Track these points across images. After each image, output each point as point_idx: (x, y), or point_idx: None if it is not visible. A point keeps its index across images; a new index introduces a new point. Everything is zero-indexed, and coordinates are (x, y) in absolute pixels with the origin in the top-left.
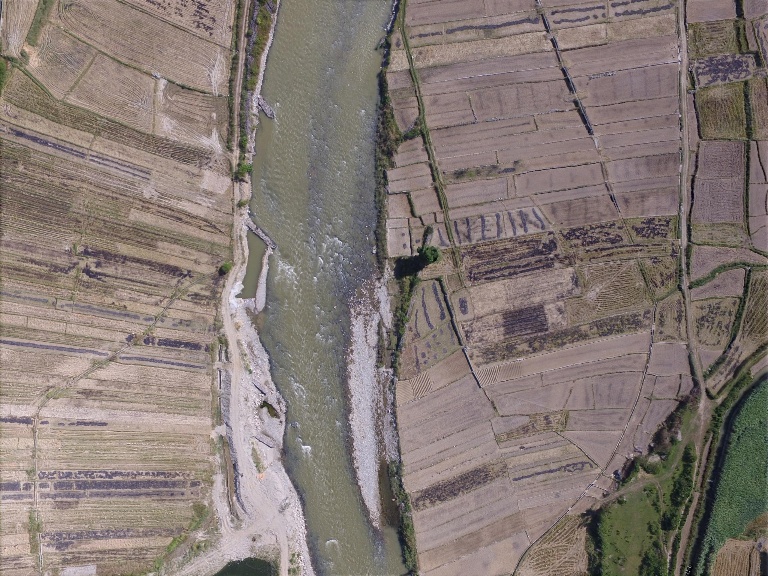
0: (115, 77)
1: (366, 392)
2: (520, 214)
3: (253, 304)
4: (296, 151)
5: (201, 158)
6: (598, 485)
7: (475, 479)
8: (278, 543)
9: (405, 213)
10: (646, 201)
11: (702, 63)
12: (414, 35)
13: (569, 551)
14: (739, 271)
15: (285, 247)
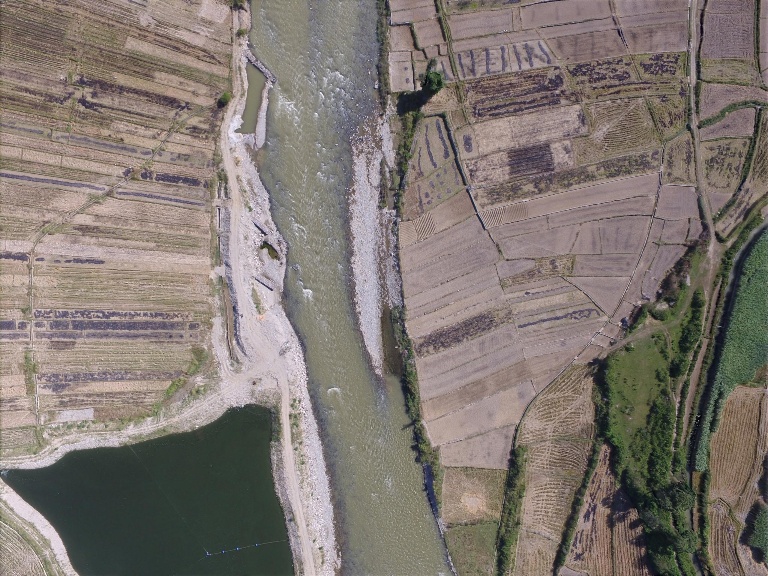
0: None
1: (368, 234)
2: (525, 47)
3: (253, 140)
4: None
5: None
6: (605, 333)
7: (480, 325)
8: (279, 387)
9: (408, 46)
10: (654, 37)
11: None
12: None
13: (575, 402)
14: (749, 110)
15: (285, 81)
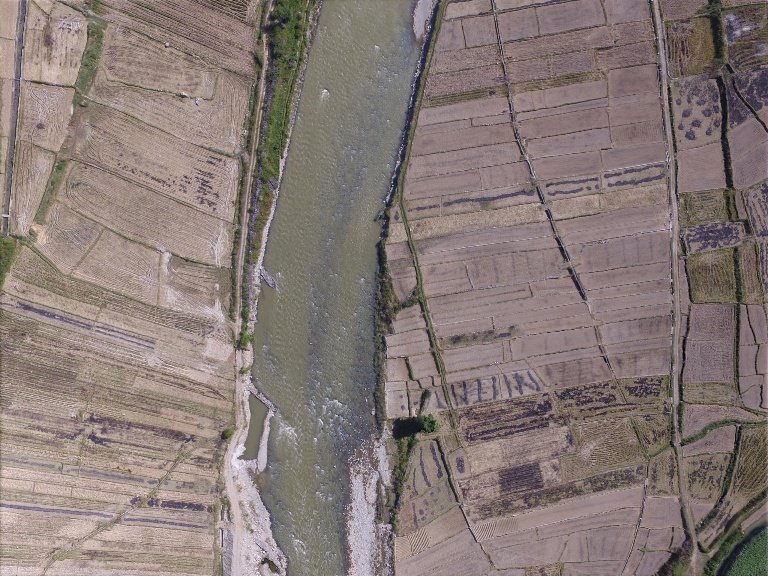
0: (121, 252)
1: (365, 547)
2: (516, 377)
3: (255, 465)
4: (297, 318)
5: (204, 327)
6: None
7: None
8: None
9: (403, 376)
10: (639, 362)
11: (693, 231)
12: (412, 208)
13: None
14: (730, 428)
15: (286, 410)
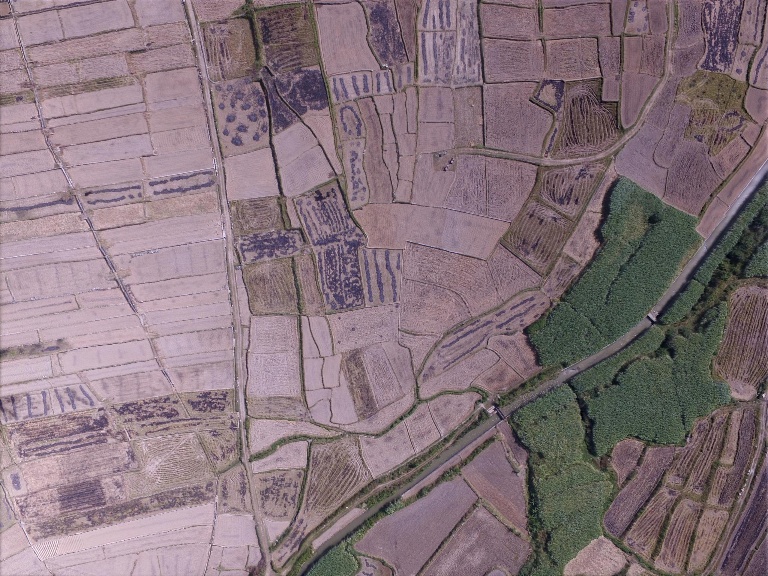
0: None
1: None
2: (67, 391)
3: None
4: None
5: None
6: None
7: None
8: None
9: None
10: (201, 375)
11: (247, 240)
12: None
13: None
14: (301, 443)
15: None
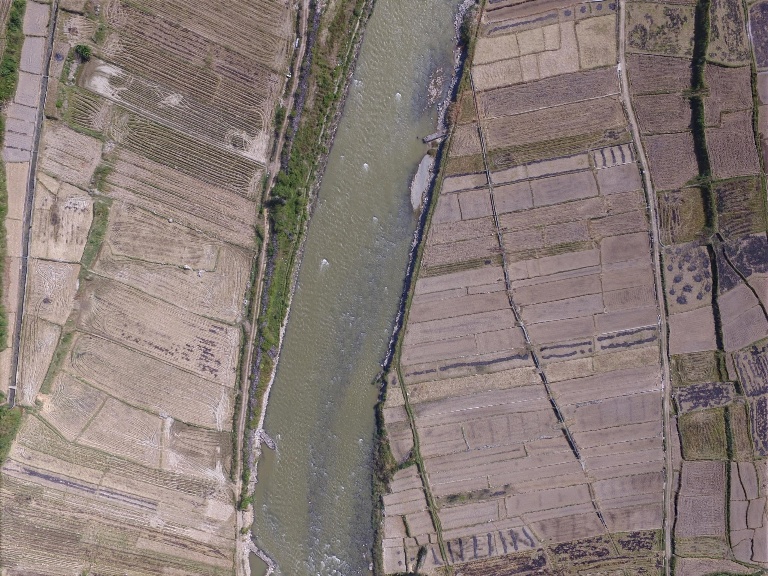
0: (124, 418)
1: None
2: (511, 533)
3: None
4: (296, 478)
5: (206, 489)
6: None
7: None
8: None
9: (400, 533)
10: (631, 516)
11: (684, 391)
12: (409, 373)
13: None
14: None
15: (285, 566)
